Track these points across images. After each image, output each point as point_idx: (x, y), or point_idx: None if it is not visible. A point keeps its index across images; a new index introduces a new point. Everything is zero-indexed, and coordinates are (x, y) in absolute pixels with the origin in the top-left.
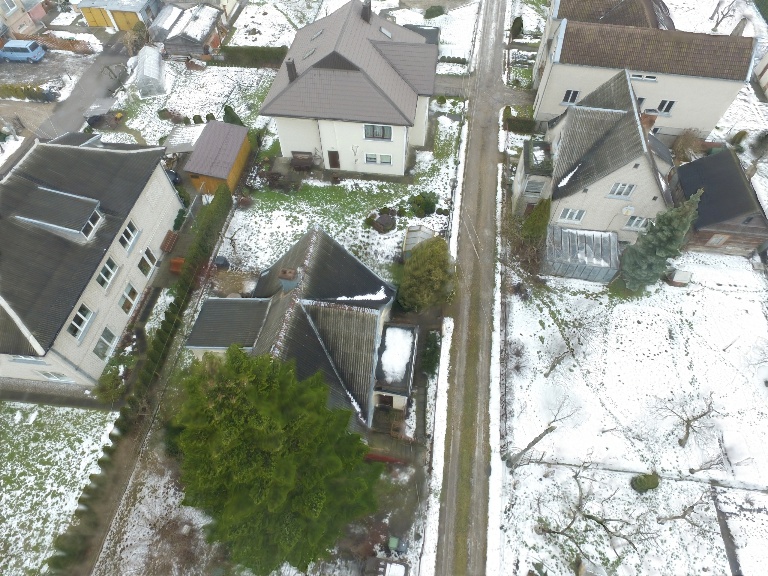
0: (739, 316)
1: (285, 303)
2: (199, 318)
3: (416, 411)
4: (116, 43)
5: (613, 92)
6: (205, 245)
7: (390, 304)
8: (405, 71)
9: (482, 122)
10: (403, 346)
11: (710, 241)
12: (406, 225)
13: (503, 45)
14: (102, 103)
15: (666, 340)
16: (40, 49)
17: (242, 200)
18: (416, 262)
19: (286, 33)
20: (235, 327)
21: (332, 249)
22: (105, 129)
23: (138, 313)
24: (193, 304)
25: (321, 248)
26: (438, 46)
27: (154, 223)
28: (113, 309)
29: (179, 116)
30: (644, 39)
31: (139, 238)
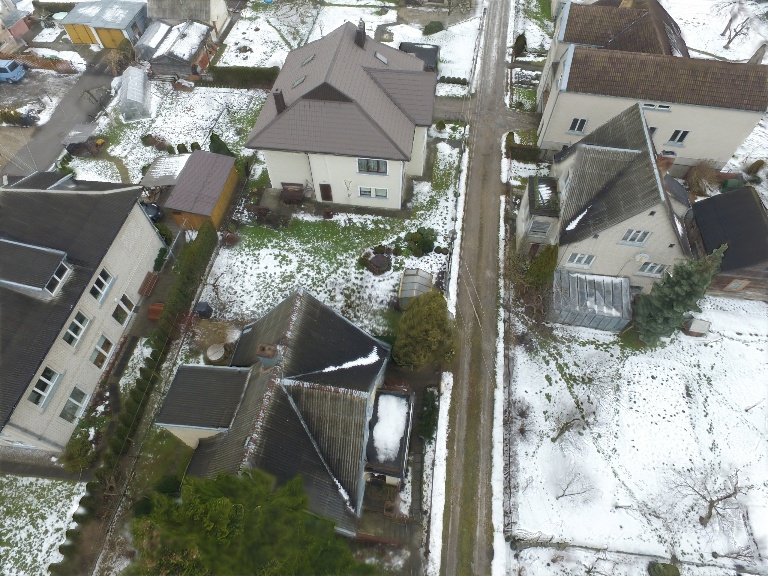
0: (761, 371)
1: (264, 383)
2: (172, 389)
3: (412, 482)
4: (100, 62)
5: (625, 128)
6: (186, 290)
7: (383, 366)
8: (401, 100)
9: (483, 149)
10: (397, 417)
11: (729, 286)
12: (402, 265)
13: (505, 64)
14: (82, 129)
15: (683, 398)
16: (20, 69)
17: (228, 237)
18: (412, 320)
19: (279, 51)
20: (210, 402)
21: (318, 313)
22: (85, 156)
23: (112, 366)
24: (172, 356)
25: (306, 314)
26: (437, 65)
27: (131, 267)
28: (83, 366)
29: (164, 142)
30: (657, 67)
31: (113, 286)
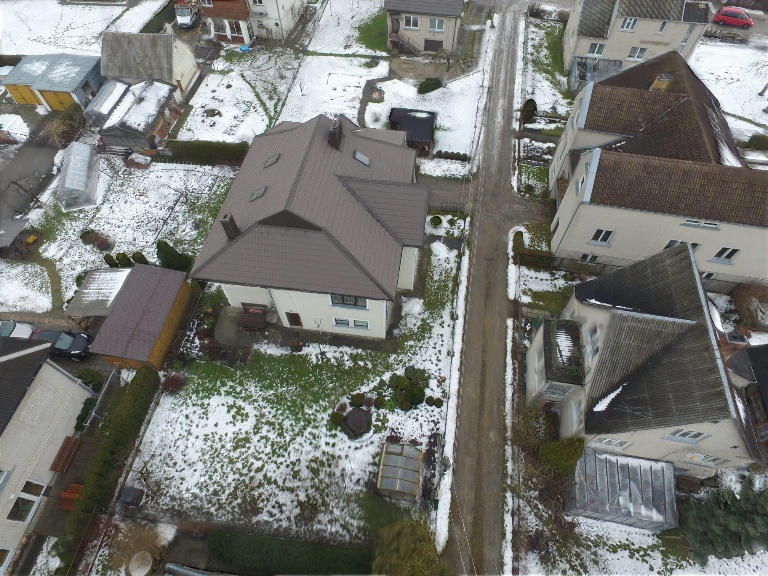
0: None
1: None
2: None
3: None
4: (45, 128)
5: (671, 276)
6: (110, 469)
7: None
8: (385, 216)
9: (487, 251)
10: None
11: None
12: (385, 424)
13: (512, 132)
14: (8, 227)
15: None
16: None
17: (172, 378)
18: None
19: (252, 114)
20: None
21: None
22: (12, 259)
23: None
24: (86, 567)
25: None
26: (433, 135)
27: (38, 444)
28: None
29: (108, 239)
30: (704, 178)
31: (8, 481)
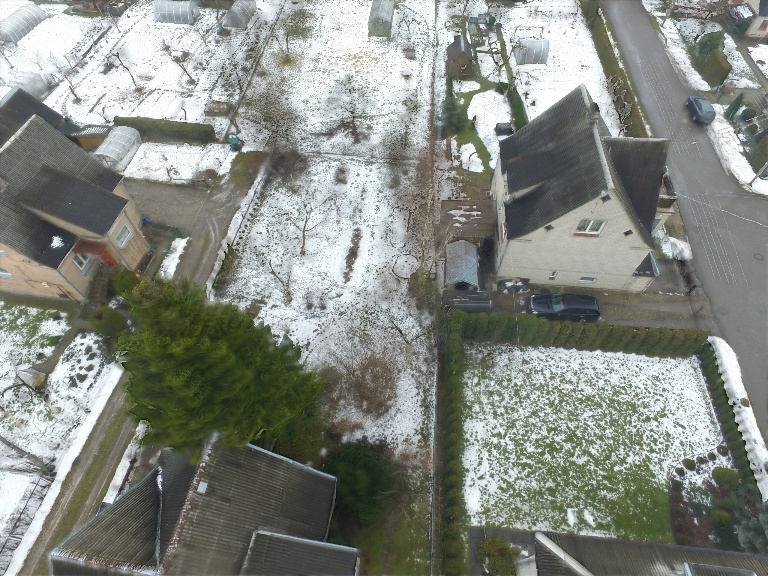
0: None
1: (182, 571)
2: None
3: None
4: None
5: None
6: None
7: None
8: None
9: None
10: None
11: None
12: None
13: None
14: None
15: None
16: None
17: None
18: None
19: None
20: (287, 575)
21: None
22: None
23: None
24: None
25: None
26: None
27: None
28: None
29: None
30: None
31: None
